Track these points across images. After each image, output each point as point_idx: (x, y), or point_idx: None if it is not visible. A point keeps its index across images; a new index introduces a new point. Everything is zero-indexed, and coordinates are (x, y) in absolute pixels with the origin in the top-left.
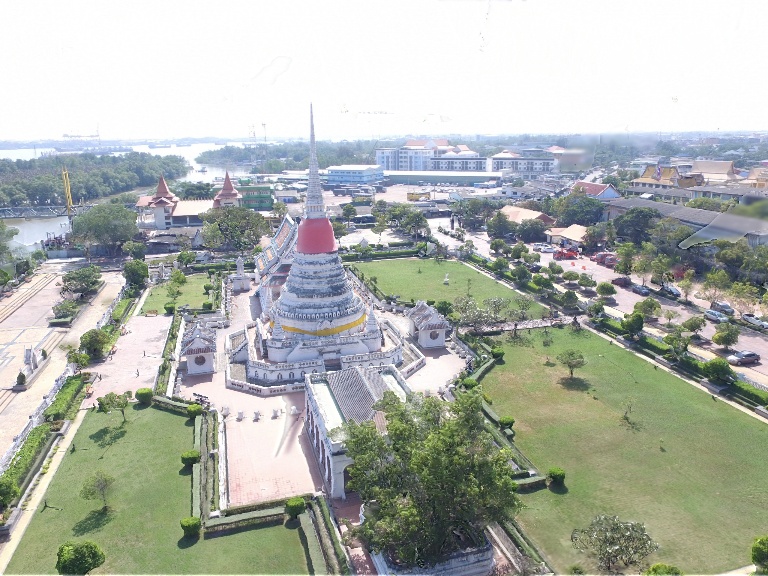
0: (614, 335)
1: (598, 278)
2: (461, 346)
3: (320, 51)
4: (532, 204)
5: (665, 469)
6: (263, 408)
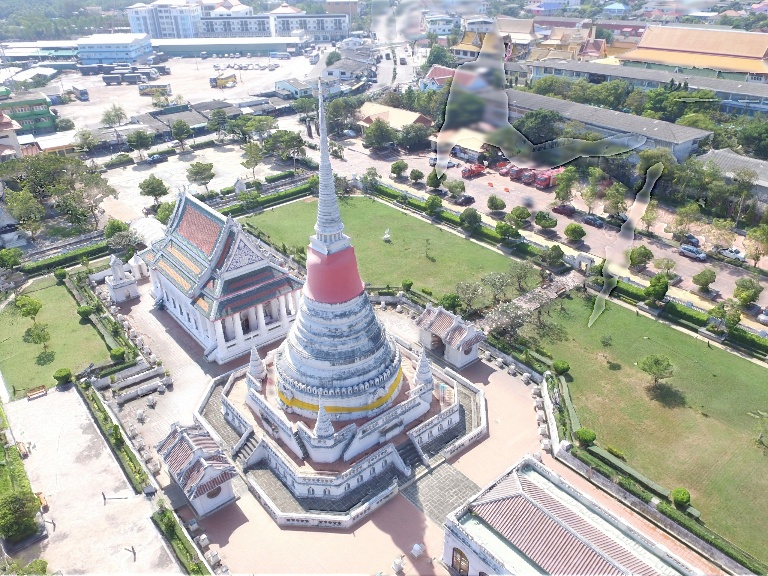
0: (632, 301)
1: (534, 205)
2: (498, 355)
3: (500, 60)
4: (392, 98)
5: None
6: (368, 557)
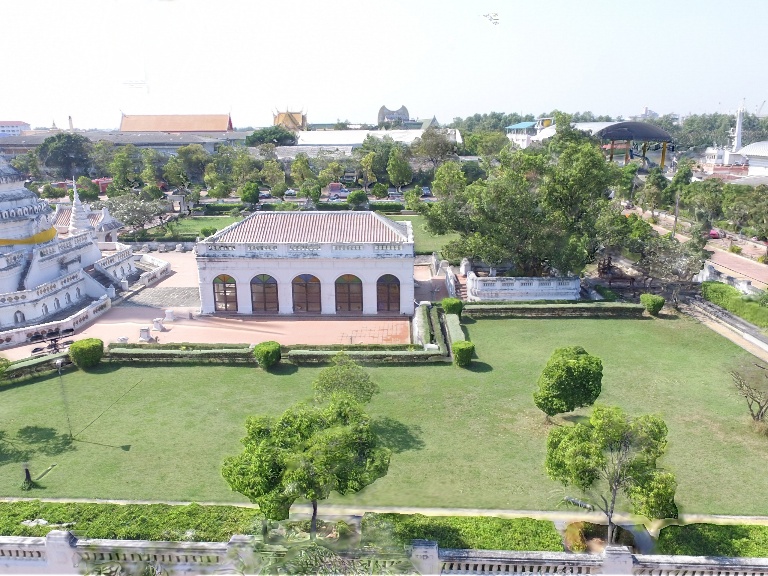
0: None
1: None
2: (140, 246)
3: None
4: None
5: (455, 235)
6: (117, 335)
